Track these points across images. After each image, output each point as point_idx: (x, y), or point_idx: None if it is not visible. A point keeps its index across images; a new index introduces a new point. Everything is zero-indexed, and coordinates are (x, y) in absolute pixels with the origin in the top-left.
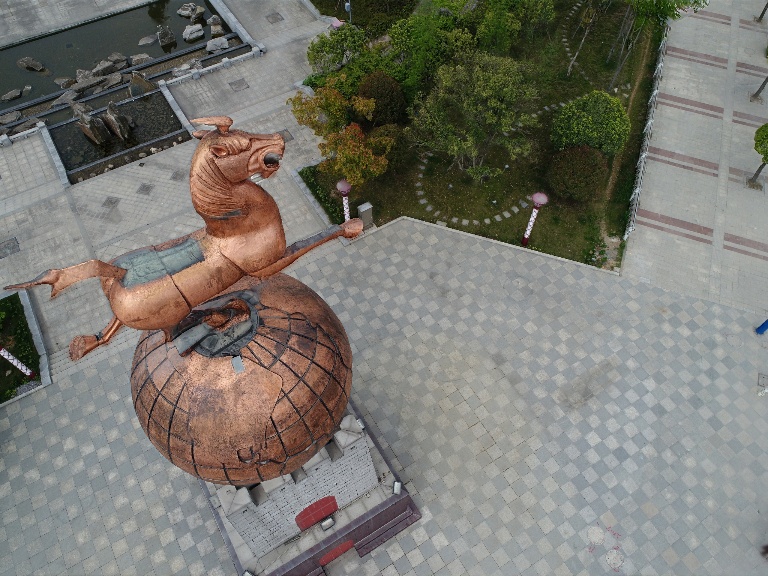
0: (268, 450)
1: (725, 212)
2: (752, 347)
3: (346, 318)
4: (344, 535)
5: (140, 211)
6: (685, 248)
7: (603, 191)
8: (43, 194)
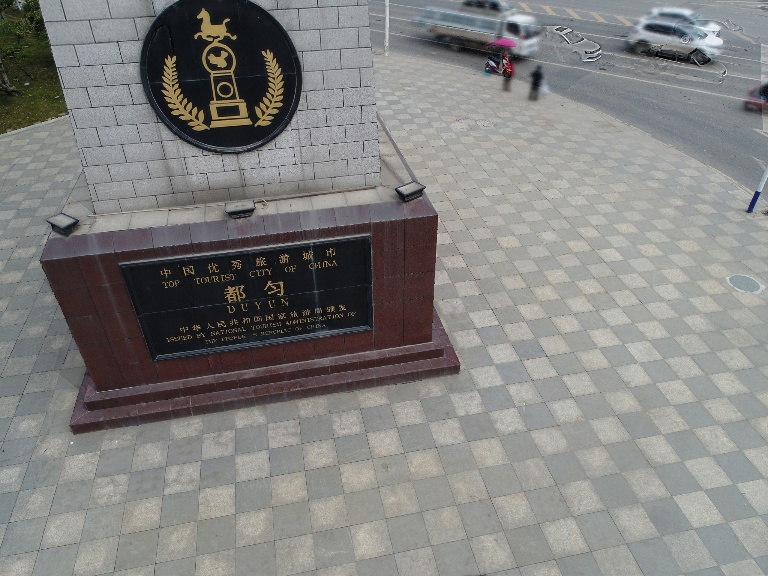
0: None
1: None
2: None
3: (50, 210)
4: None
5: None
6: None
7: None
8: None
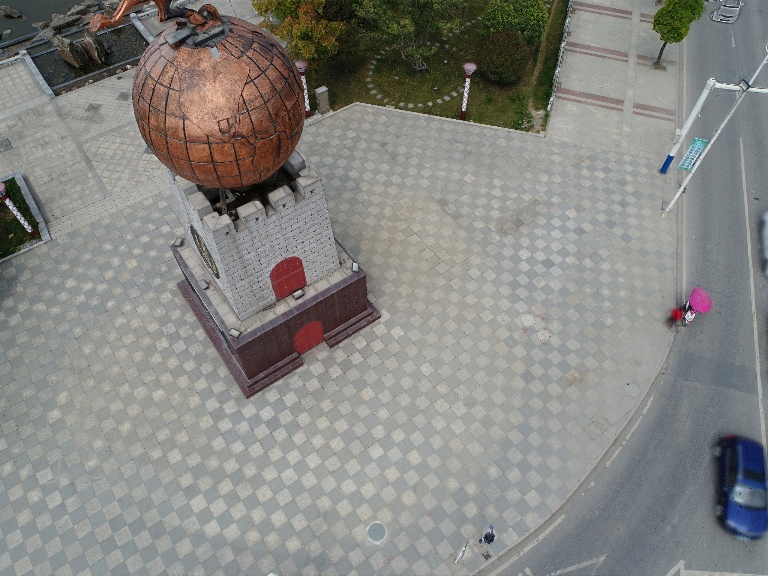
0: (241, 125)
1: (634, 87)
2: (657, 183)
3: None
4: (313, 305)
5: (120, 113)
6: (600, 115)
7: (530, 77)
8: (30, 105)
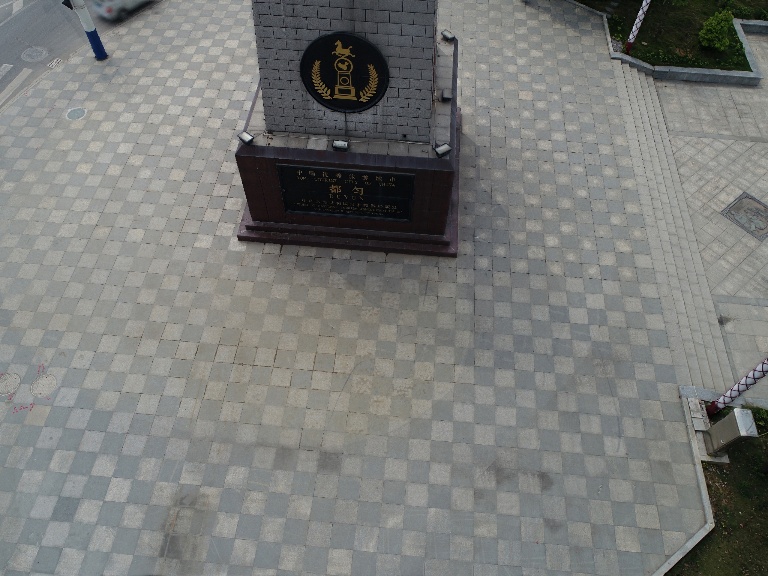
0: None
1: None
2: None
3: (537, 313)
4: None
5: None
6: None
7: None
8: None
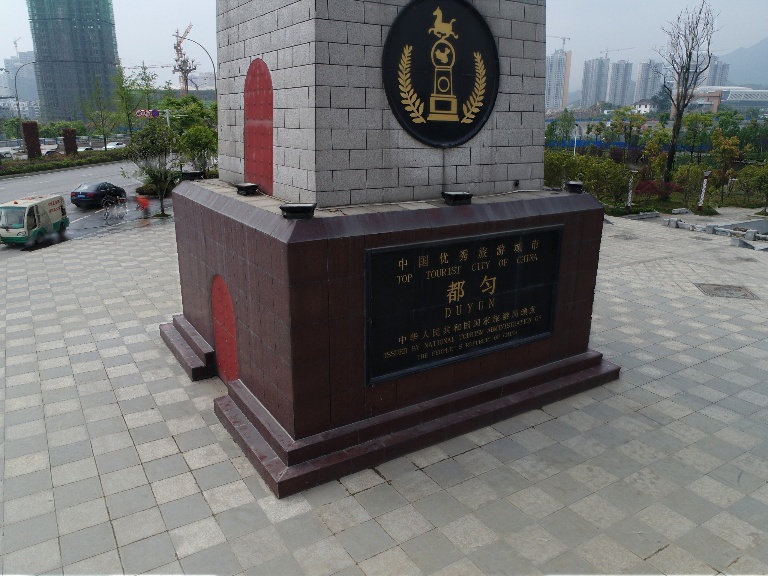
0: None
1: None
2: None
3: None
4: None
5: (759, 270)
6: None
7: None
8: None
